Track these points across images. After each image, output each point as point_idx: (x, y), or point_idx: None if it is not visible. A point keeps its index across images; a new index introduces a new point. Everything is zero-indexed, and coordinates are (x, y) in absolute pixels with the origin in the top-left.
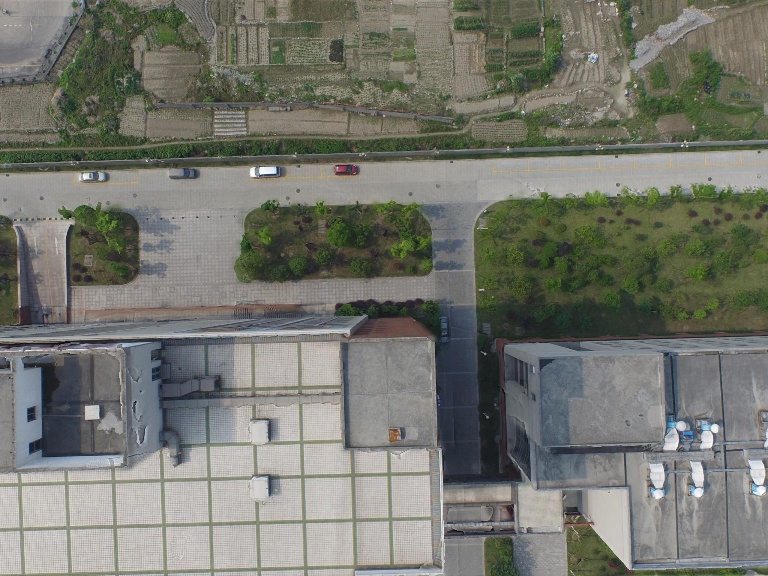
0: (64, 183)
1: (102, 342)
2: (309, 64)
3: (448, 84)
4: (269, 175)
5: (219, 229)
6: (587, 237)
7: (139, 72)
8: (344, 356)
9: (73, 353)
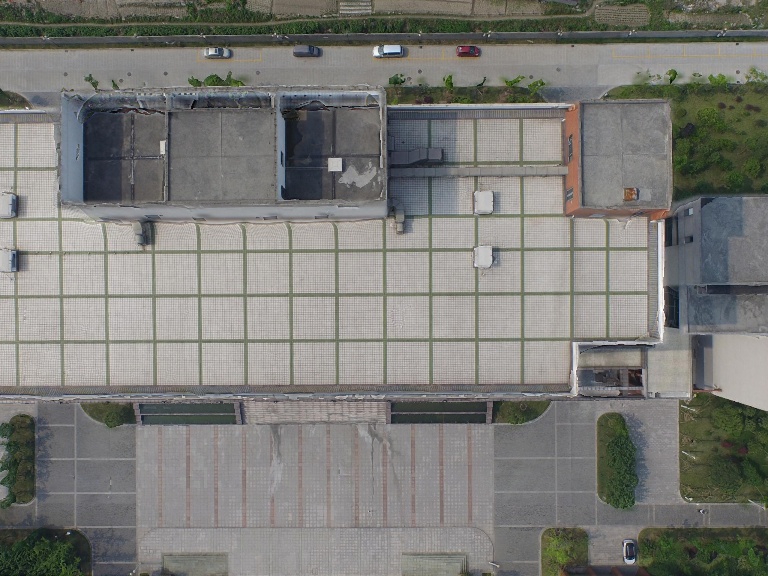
0: (188, 59)
1: (335, 107)
2: None
3: None
4: (393, 54)
5: None
6: (710, 119)
7: None
8: (582, 116)
9: None
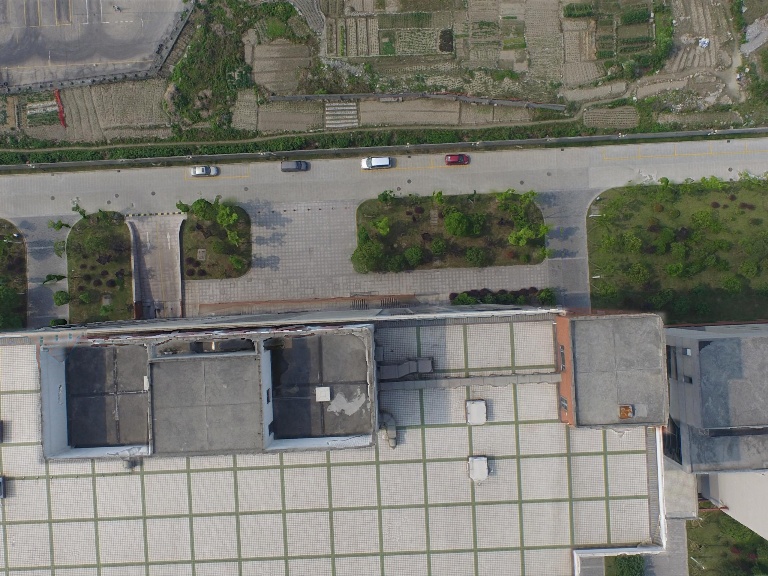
0: (175, 178)
1: (321, 325)
2: (419, 54)
3: (559, 72)
4: (381, 166)
5: (331, 221)
6: (704, 222)
7: (250, 66)
8: (573, 334)
9: (319, 333)
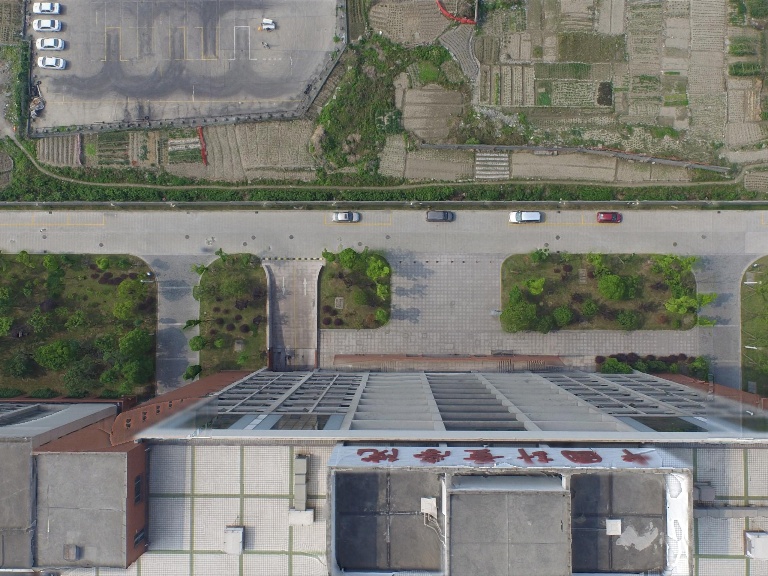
0: (315, 222)
1: (601, 446)
2: (576, 107)
3: (721, 131)
4: (531, 221)
5: (474, 275)
6: None
7: (400, 110)
8: None
9: (637, 472)
